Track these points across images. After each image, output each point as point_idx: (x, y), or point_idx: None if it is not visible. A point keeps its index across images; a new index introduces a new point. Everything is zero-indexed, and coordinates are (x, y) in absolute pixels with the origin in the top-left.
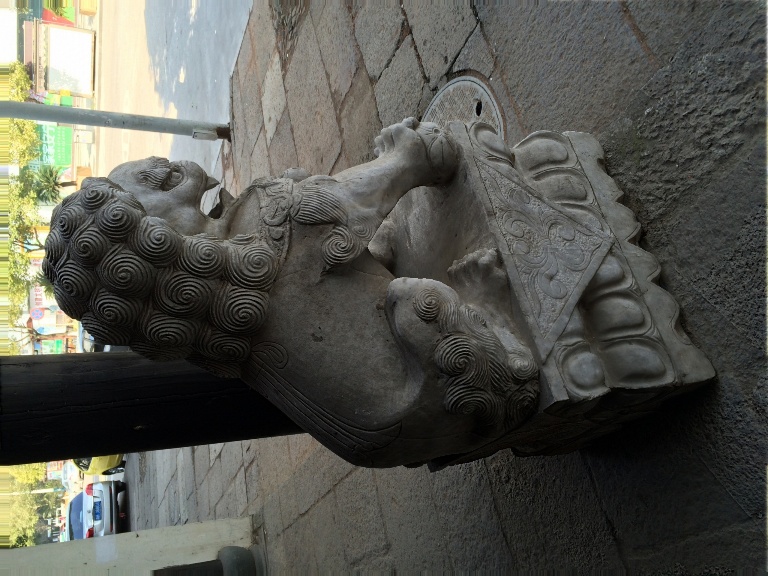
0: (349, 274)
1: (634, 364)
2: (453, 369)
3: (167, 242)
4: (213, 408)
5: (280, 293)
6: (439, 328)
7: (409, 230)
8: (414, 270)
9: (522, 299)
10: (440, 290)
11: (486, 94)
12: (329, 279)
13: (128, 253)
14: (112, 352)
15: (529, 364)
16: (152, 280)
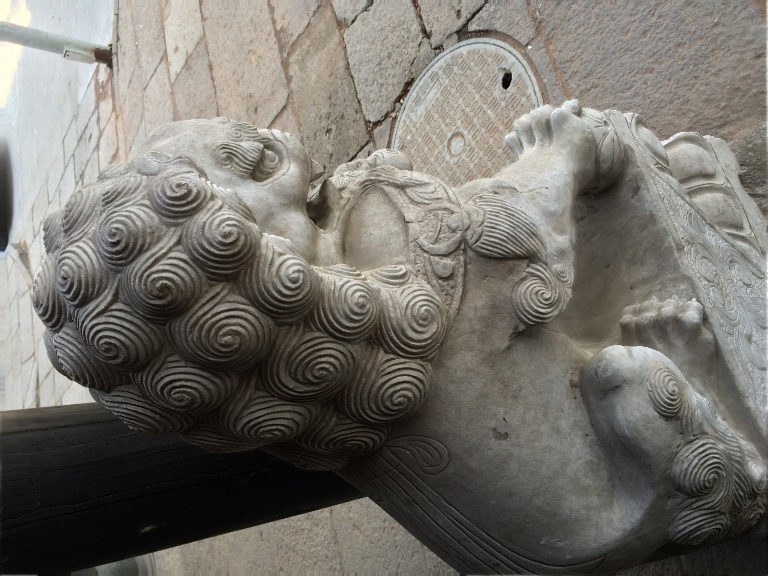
0: (536, 334)
1: None
2: (699, 489)
3: (305, 284)
4: (249, 488)
5: (449, 364)
6: (681, 428)
7: None
8: None
9: (736, 373)
10: (669, 367)
11: (520, 64)
12: (517, 343)
13: (238, 301)
14: (98, 406)
15: (763, 470)
16: (268, 345)
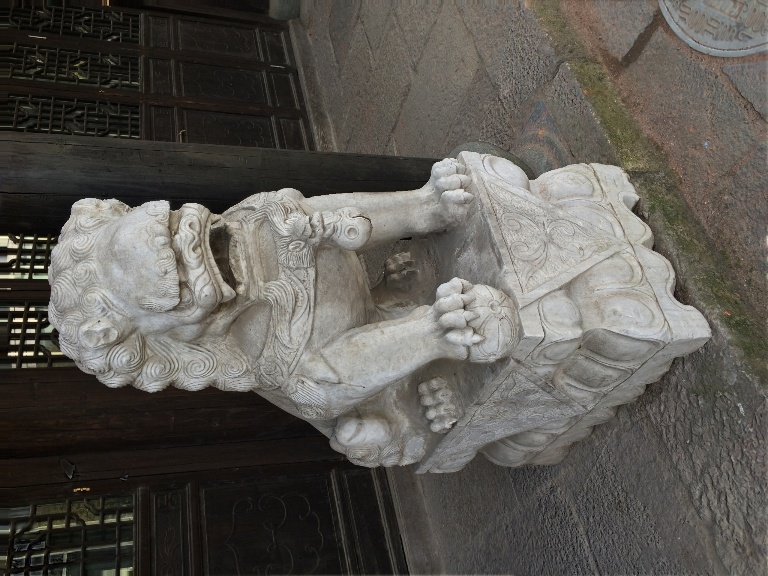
0: None
1: (500, 459)
2: None
3: None
4: None
5: None
6: None
7: (465, 251)
8: (444, 270)
9: (445, 442)
10: None
11: None
12: None
13: None
14: (131, 180)
15: None
16: None
